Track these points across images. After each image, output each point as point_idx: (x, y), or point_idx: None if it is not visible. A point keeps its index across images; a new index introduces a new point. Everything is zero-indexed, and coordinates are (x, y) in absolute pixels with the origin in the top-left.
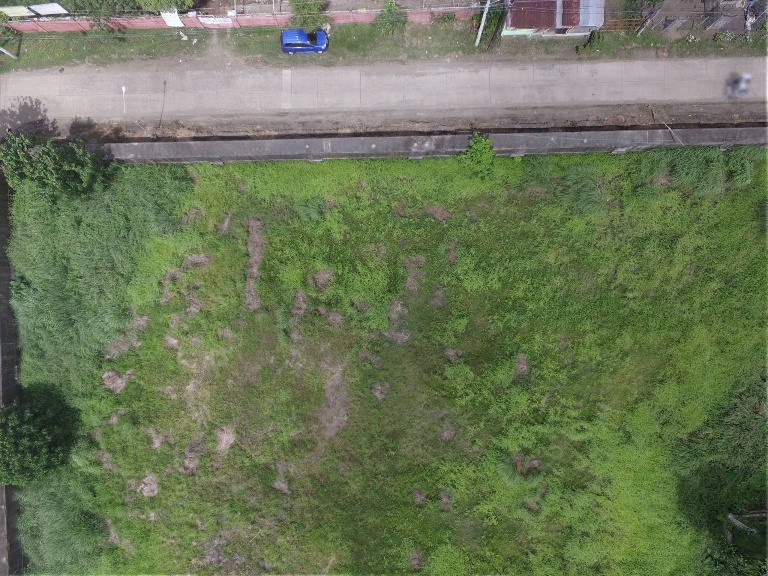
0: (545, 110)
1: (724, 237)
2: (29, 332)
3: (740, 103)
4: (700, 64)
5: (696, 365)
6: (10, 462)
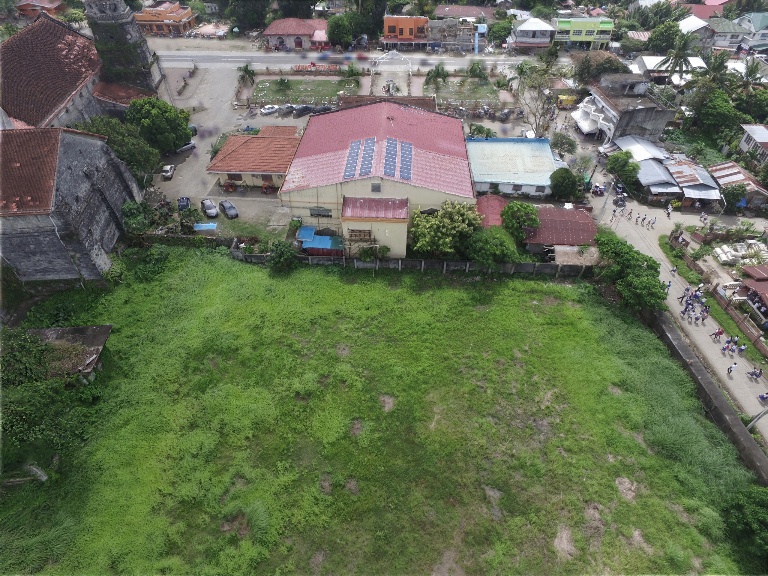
0: None
1: None
2: None
3: None
4: None
5: None
6: None
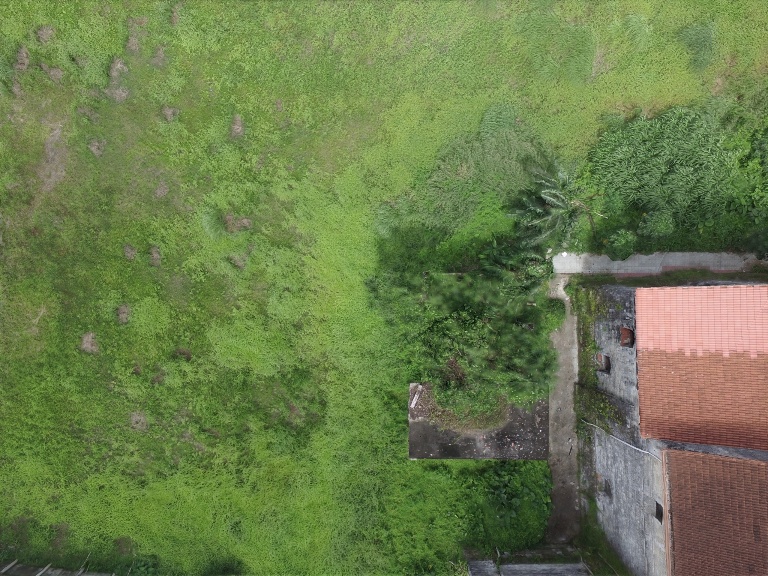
0: None
1: (439, 7)
2: None
3: None
4: None
5: (404, 128)
6: None
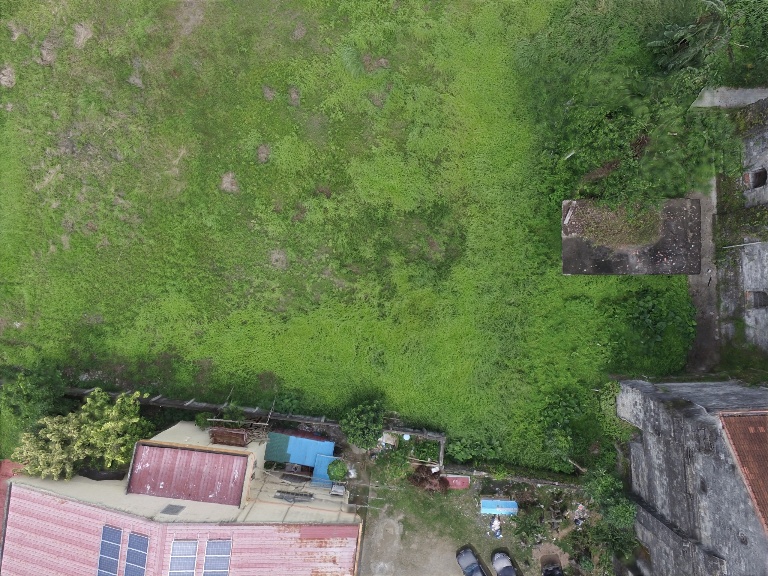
0: None
1: None
2: None
3: None
4: None
5: None
6: None
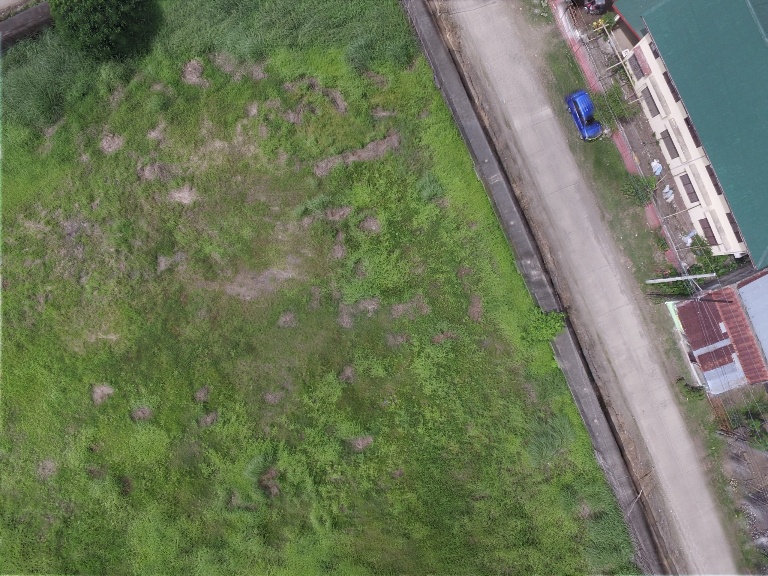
0: (611, 371)
1: None
2: None
3: (691, 553)
4: (713, 501)
5: None
6: (82, 3)
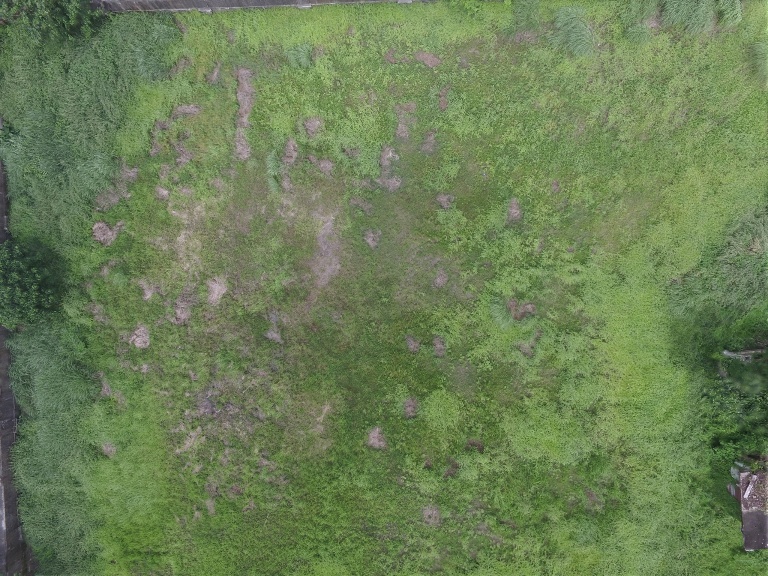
0: None
1: (716, 78)
2: (18, 179)
3: None
4: None
5: (689, 205)
6: None
